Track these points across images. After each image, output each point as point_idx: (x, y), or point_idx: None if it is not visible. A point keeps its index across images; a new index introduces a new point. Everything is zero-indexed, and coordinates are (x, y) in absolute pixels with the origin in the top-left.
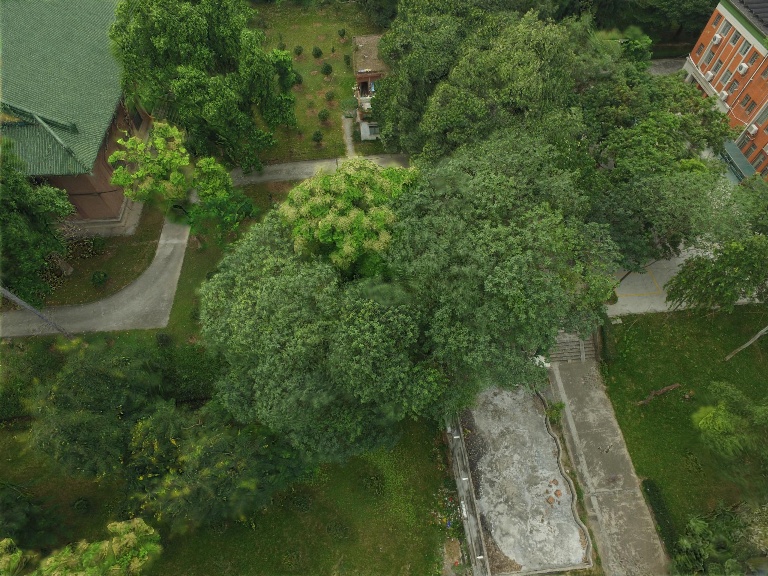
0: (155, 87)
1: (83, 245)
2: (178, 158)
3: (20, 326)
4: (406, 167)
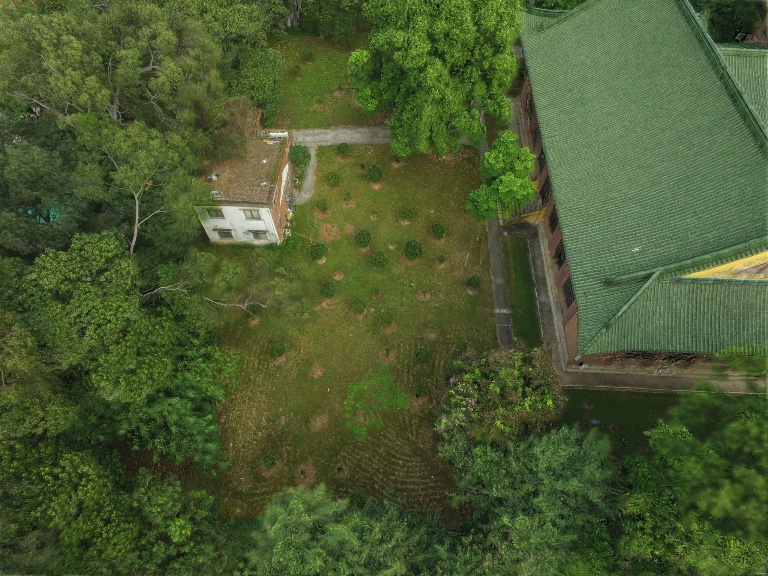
0: None
1: None
2: None
3: None
4: None
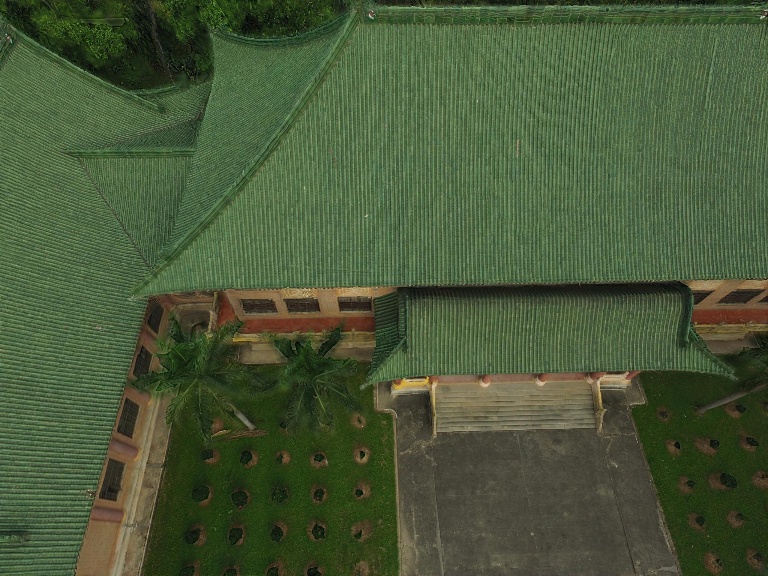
0: None
1: None
2: None
3: None
4: None
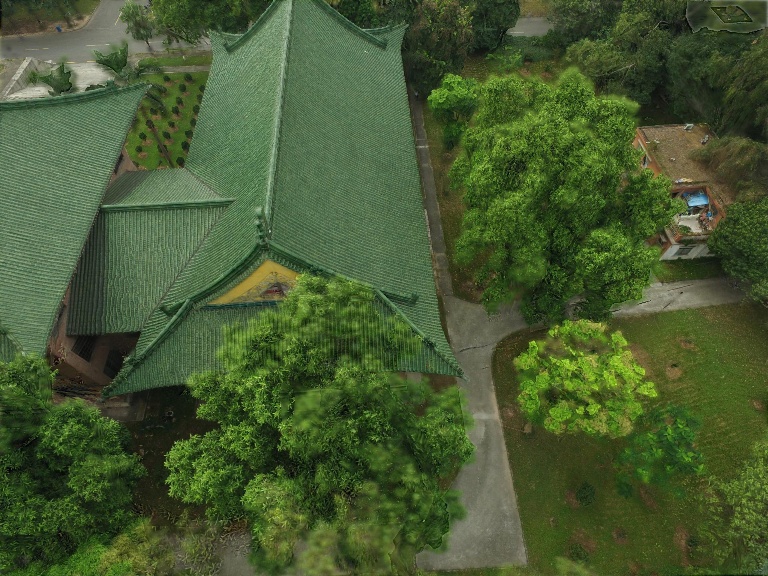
0: (535, 250)
1: (365, 420)
2: (642, 386)
3: (326, 558)
4: (727, 300)
